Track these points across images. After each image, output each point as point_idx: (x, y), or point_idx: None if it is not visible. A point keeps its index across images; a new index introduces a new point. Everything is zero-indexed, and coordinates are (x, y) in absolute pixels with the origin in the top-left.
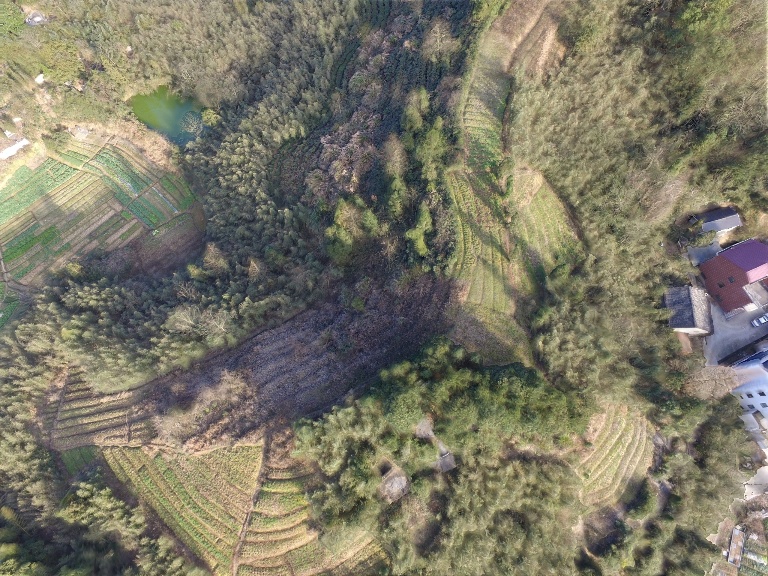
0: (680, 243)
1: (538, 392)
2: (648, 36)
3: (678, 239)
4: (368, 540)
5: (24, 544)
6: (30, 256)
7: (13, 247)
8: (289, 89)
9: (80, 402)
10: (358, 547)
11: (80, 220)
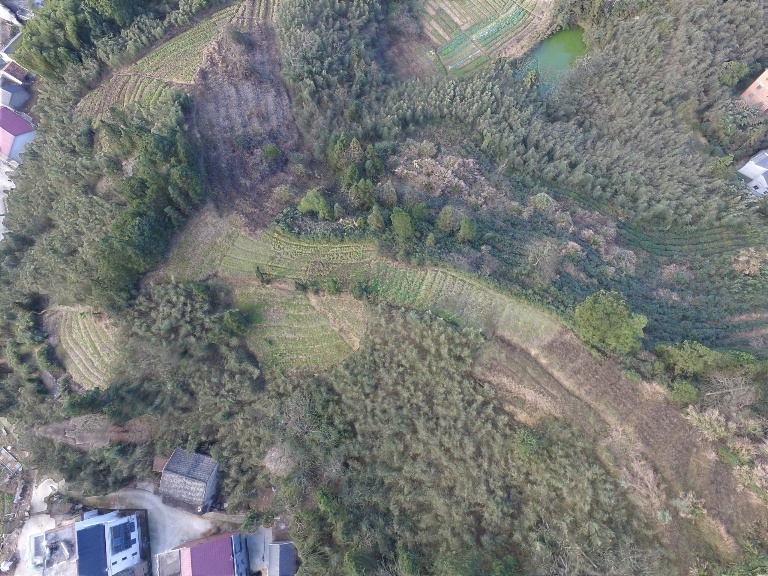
0: (275, 519)
1: None
2: (518, 534)
3: (276, 514)
4: None
5: None
6: None
7: None
8: (549, 141)
9: None
10: None
11: (458, 2)
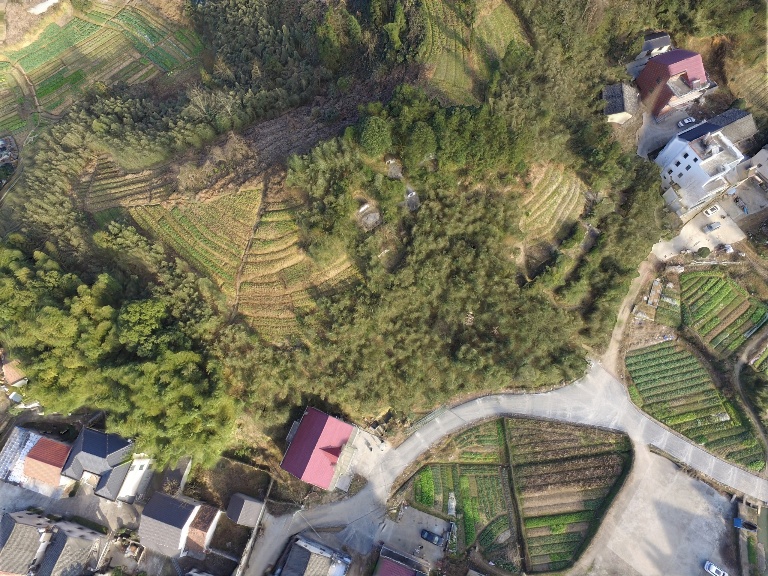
0: (621, 63)
1: (483, 118)
2: None
3: (618, 58)
4: (347, 264)
5: (64, 271)
6: (60, 93)
7: (45, 86)
8: None
9: (108, 180)
10: (339, 269)
11: (103, 65)
